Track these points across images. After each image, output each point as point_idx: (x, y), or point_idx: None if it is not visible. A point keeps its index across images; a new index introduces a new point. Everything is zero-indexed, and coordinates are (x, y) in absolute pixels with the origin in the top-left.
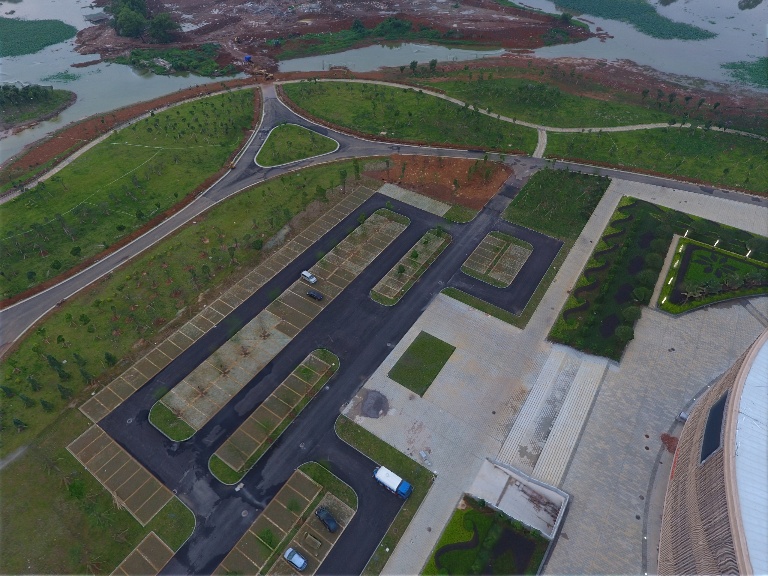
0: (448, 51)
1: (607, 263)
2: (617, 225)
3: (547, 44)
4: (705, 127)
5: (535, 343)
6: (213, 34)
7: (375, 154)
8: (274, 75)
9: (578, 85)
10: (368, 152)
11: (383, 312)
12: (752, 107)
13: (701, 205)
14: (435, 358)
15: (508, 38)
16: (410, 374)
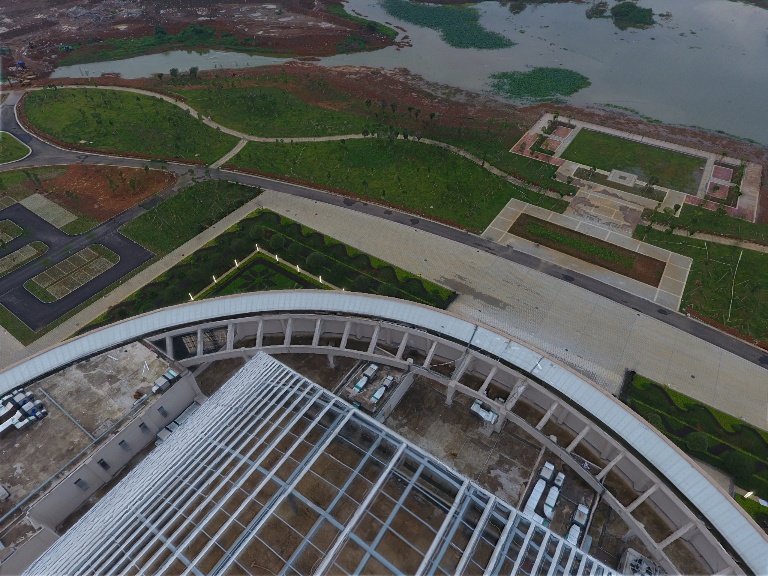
0: (243, 58)
1: (171, 277)
2: (221, 238)
3: (340, 52)
4: (388, 138)
5: None
6: (15, 39)
7: (56, 163)
8: (37, 81)
9: (324, 94)
10: (51, 161)
11: None
12: (480, 118)
13: (328, 218)
14: None
15: (303, 45)
16: None
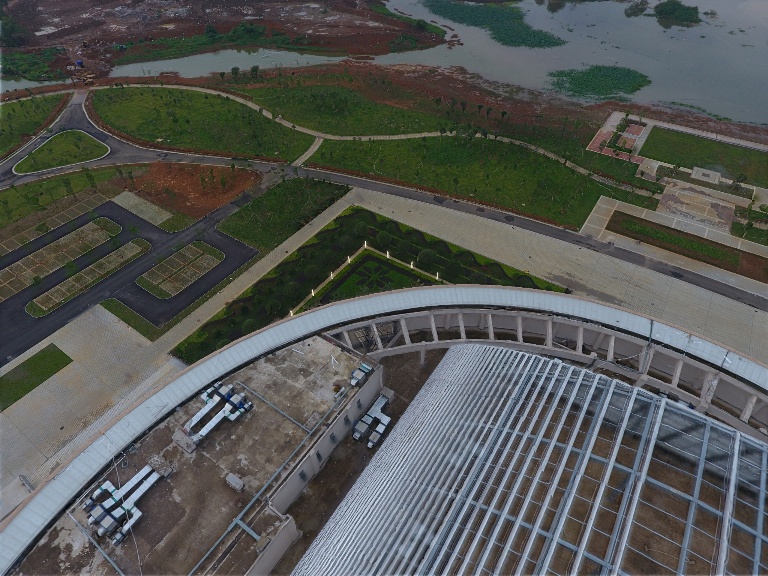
0: (295, 57)
1: (281, 274)
2: (321, 235)
3: (392, 51)
4: (468, 136)
5: (155, 356)
6: (67, 38)
7: (138, 161)
8: (98, 80)
9: (388, 92)
10: (132, 159)
11: (27, 324)
12: (549, 116)
13: (422, 215)
14: (44, 371)
15: (355, 44)
16: (7, 388)
